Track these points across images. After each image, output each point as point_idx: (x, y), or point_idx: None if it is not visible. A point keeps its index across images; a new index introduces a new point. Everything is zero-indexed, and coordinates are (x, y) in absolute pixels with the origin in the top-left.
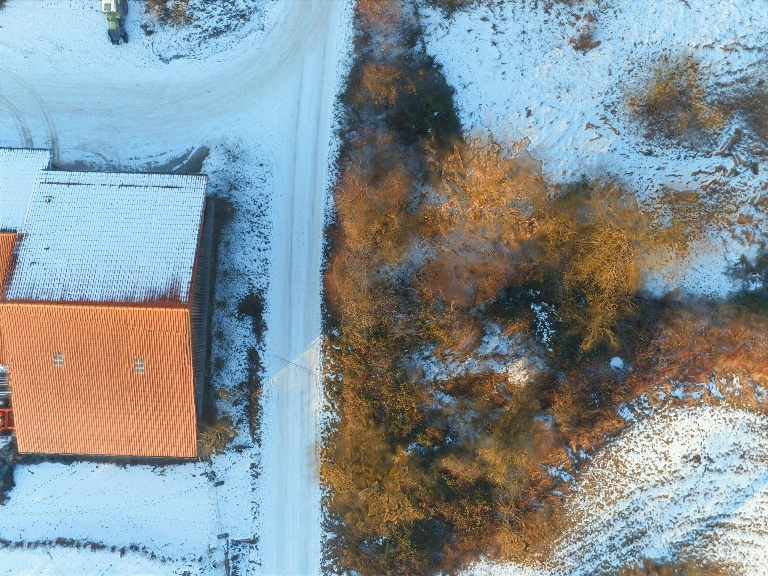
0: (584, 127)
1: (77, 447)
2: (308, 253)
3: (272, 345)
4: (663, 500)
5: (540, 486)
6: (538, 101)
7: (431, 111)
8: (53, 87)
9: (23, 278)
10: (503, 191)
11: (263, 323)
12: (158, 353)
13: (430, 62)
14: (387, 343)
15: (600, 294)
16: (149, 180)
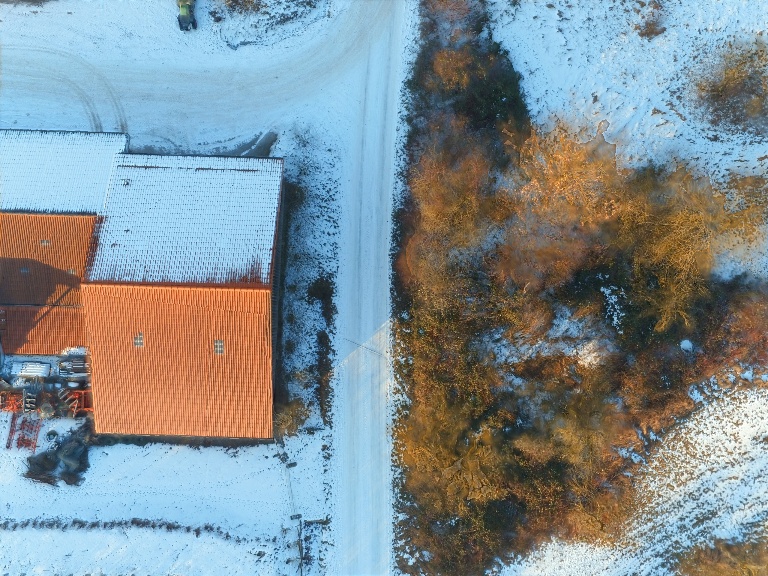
0: (650, 113)
1: (154, 428)
2: (377, 237)
3: (342, 328)
4: (733, 482)
5: (611, 468)
6: (604, 87)
7: (500, 96)
8: (122, 73)
9: (105, 259)
10: (585, 173)
11: (333, 306)
12: (238, 334)
13: (497, 48)
14: (459, 326)
15: (676, 276)
16: (225, 163)
